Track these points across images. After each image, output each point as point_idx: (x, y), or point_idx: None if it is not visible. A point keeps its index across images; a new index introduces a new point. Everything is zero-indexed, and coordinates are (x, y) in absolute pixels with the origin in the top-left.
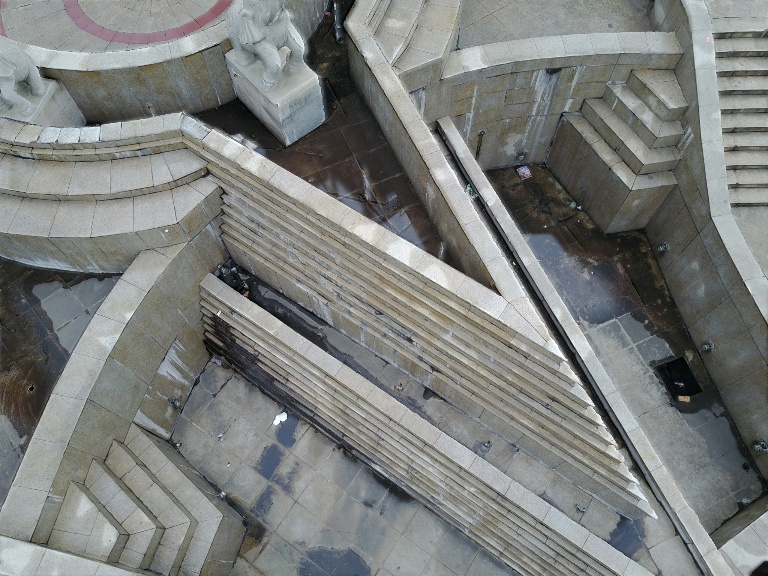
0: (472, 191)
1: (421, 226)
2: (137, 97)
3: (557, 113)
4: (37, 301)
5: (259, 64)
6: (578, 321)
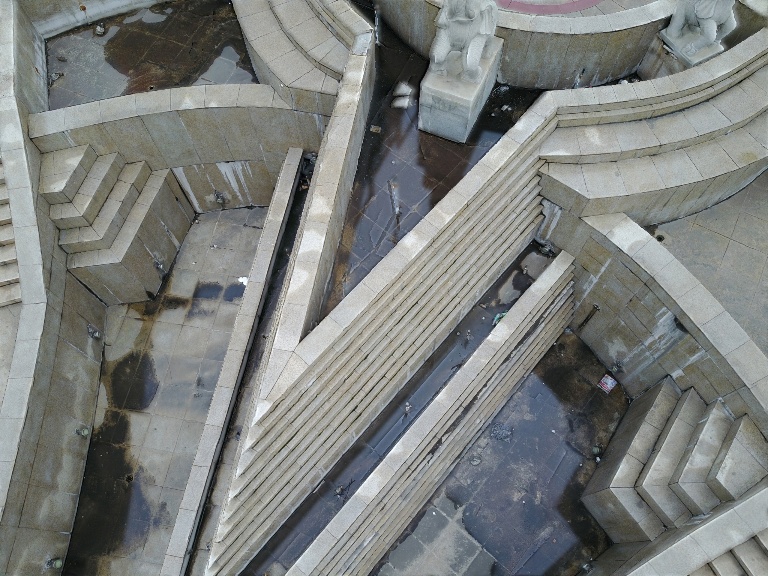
0: None
1: None
2: (390, 1)
3: (665, 369)
4: (219, 54)
5: (457, 54)
6: (458, 506)
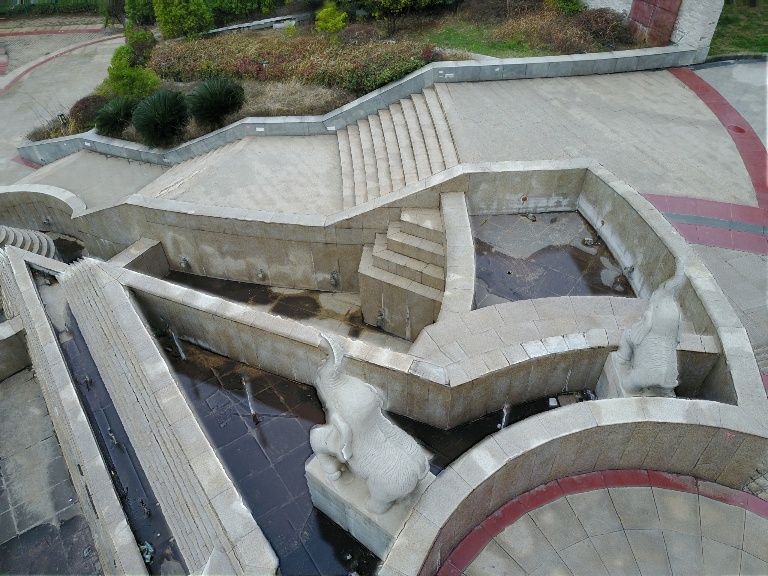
0: (144, 554)
1: (196, 398)
2: None
3: None
4: None
5: None
6: (63, 523)
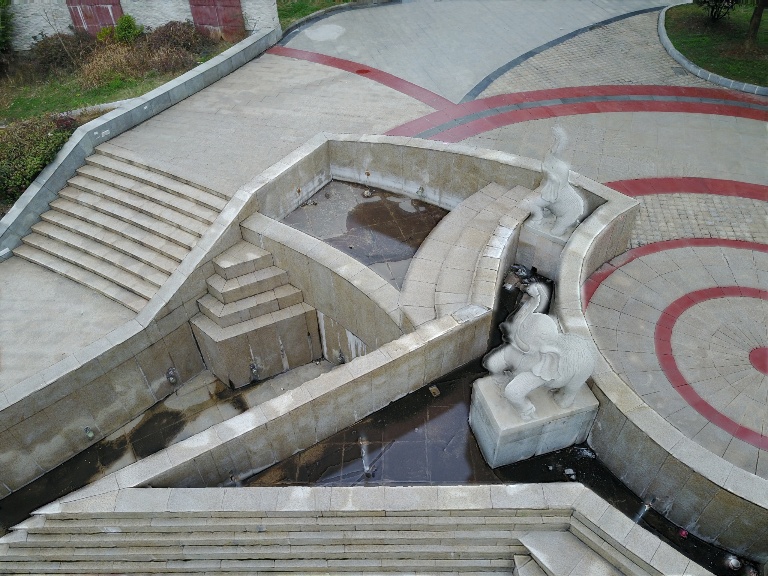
0: None
1: None
2: None
3: None
4: None
5: None
6: None
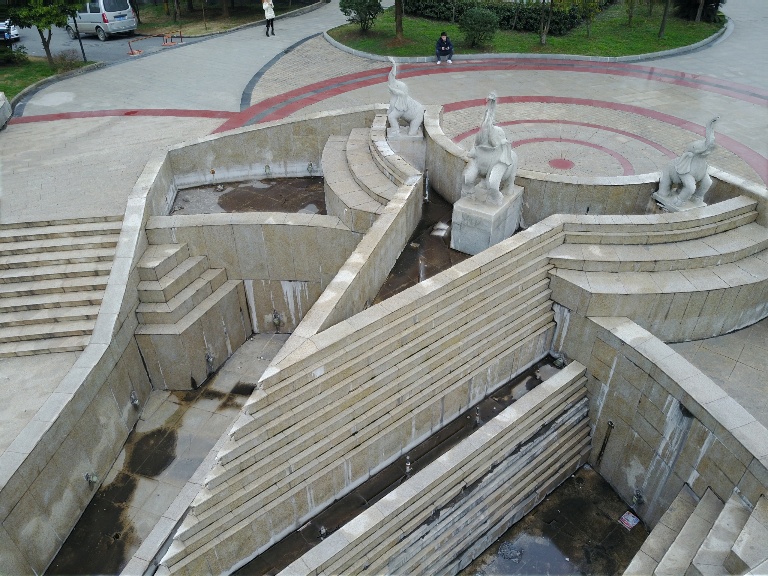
0: None
1: None
2: (440, 172)
3: (681, 478)
4: (303, 207)
5: (486, 191)
6: None
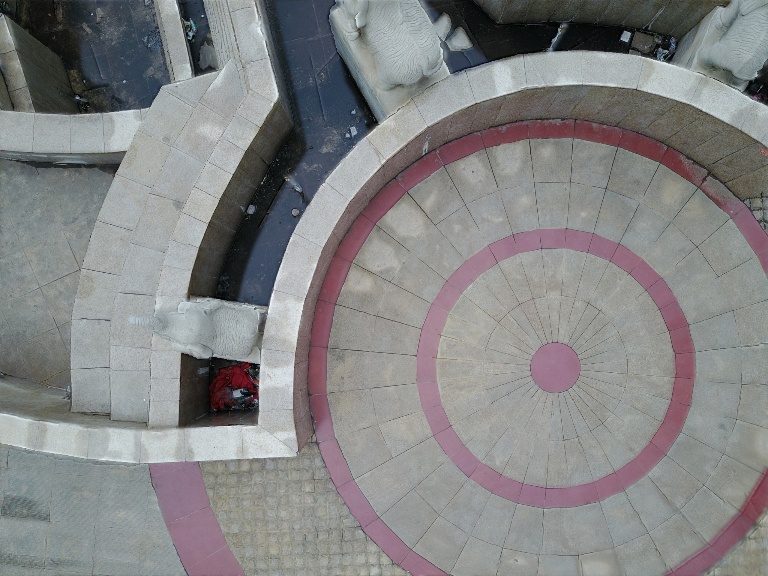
0: (187, 30)
1: None
2: None
3: None
4: None
5: None
6: None
